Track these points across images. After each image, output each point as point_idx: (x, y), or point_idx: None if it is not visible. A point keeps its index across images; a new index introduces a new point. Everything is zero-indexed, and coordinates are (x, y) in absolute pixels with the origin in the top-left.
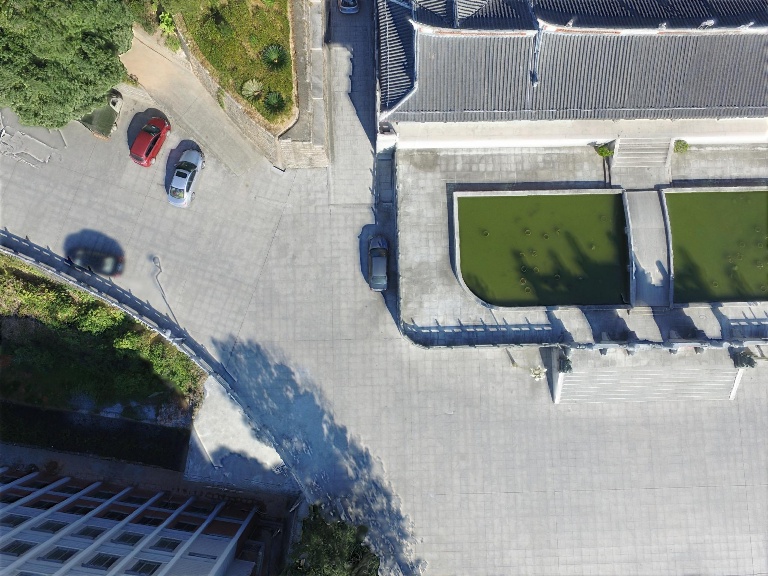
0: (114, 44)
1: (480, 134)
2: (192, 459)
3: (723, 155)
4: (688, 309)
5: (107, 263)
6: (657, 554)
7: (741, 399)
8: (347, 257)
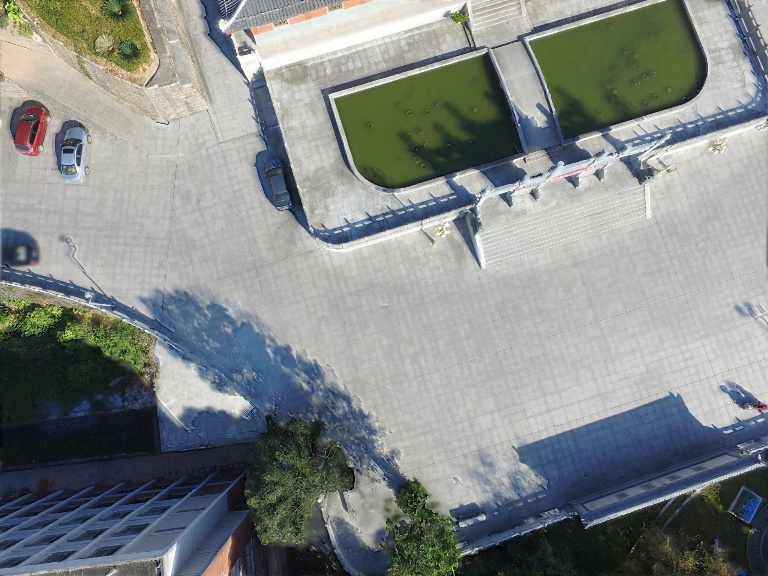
0: None
1: (337, 32)
2: (164, 430)
3: None
4: (581, 142)
5: (22, 256)
6: (617, 382)
7: (658, 215)
8: (249, 187)
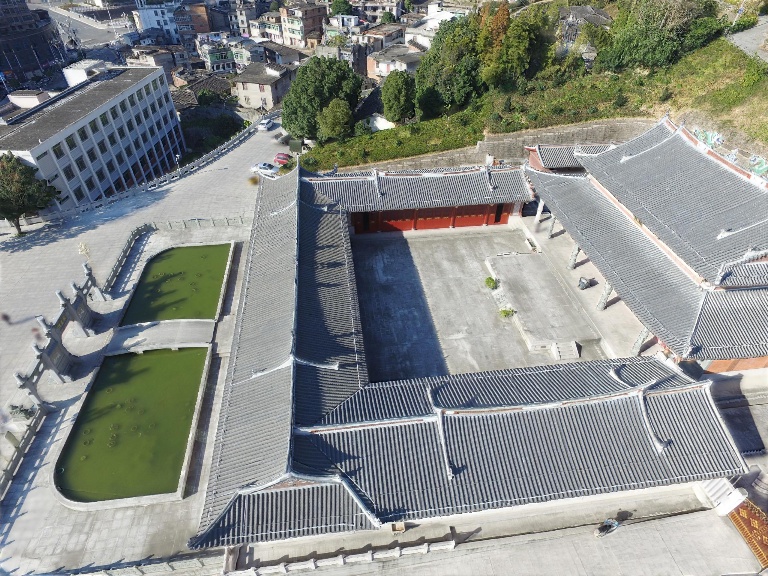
0: (317, 130)
1: None
2: None
3: None
4: None
5: (228, 158)
6: None
7: None
8: None
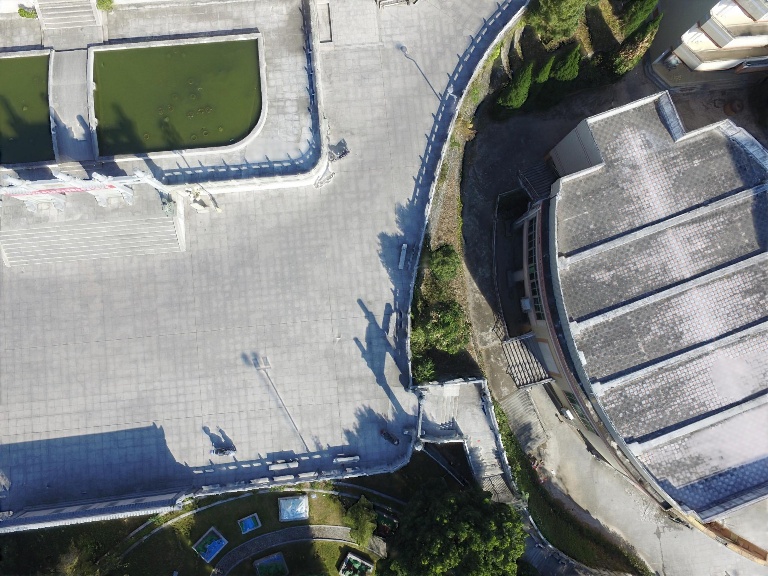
0: None
1: None
2: None
3: (162, 12)
4: (122, 163)
5: None
6: (106, 403)
7: (194, 250)
8: None
